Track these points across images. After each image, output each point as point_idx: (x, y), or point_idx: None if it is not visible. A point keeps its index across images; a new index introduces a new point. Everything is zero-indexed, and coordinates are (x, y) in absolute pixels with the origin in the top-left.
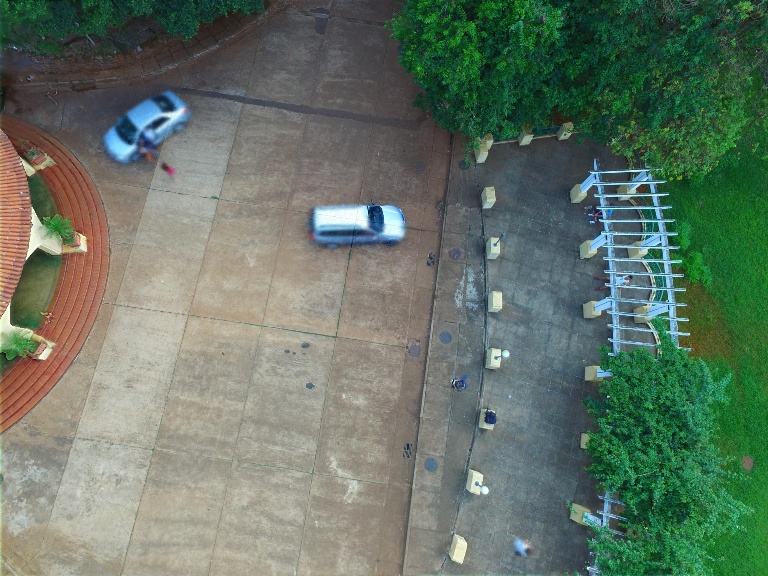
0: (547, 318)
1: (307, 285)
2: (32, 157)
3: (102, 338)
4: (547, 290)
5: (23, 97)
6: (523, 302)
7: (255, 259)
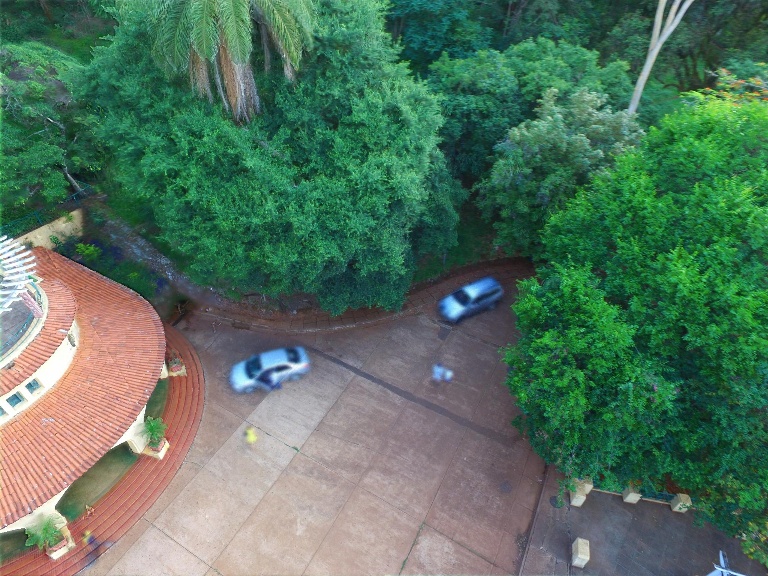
0: None
1: None
2: (173, 365)
3: (118, 557)
4: None
5: (195, 320)
6: None
7: (305, 528)
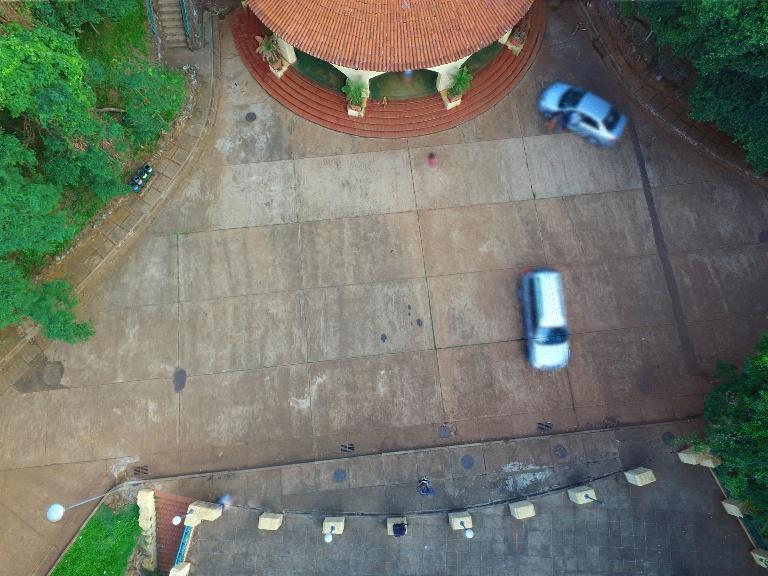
0: (523, 575)
1: (478, 307)
2: (516, 36)
3: (378, 149)
4: (555, 570)
5: (569, 6)
6: (532, 543)
7: (487, 251)
